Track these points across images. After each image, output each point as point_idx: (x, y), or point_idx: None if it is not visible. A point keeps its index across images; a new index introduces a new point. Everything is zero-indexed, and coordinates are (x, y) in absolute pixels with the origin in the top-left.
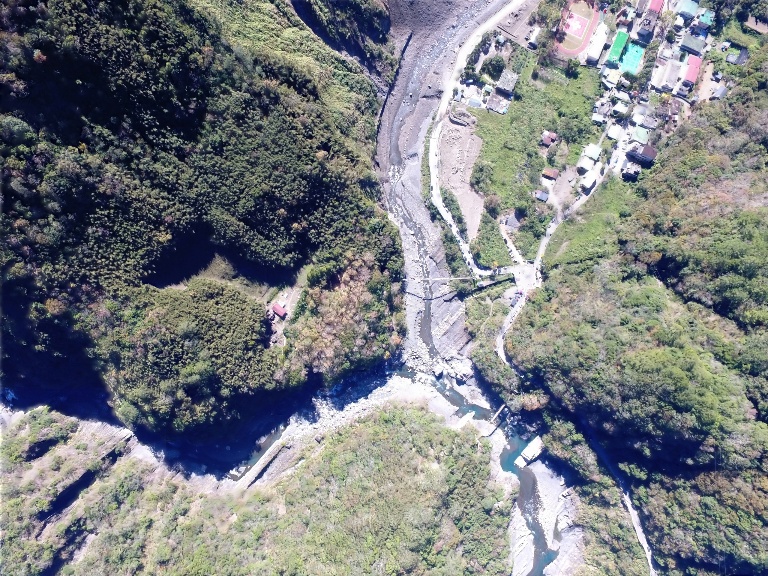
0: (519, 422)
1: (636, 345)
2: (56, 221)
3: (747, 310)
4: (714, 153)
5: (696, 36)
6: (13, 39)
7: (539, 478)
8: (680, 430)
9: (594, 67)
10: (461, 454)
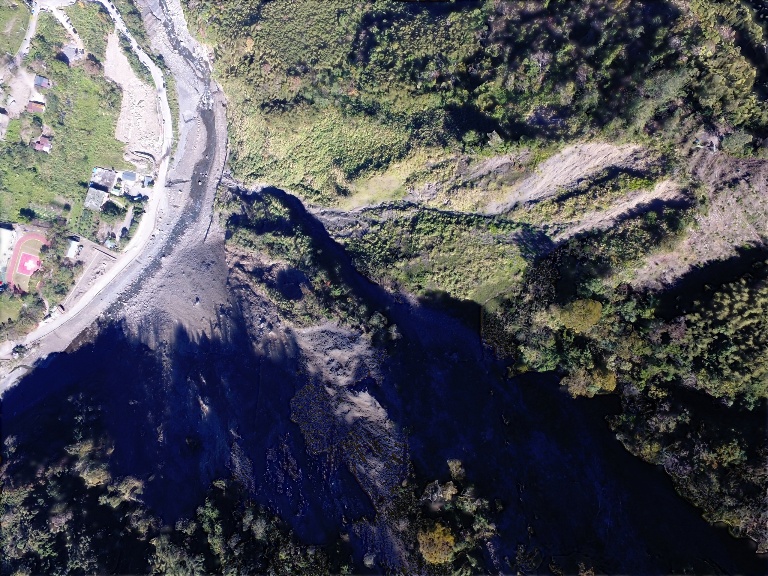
0: None
1: None
2: None
3: None
4: None
5: None
6: None
7: None
8: None
9: (3, 222)
10: None
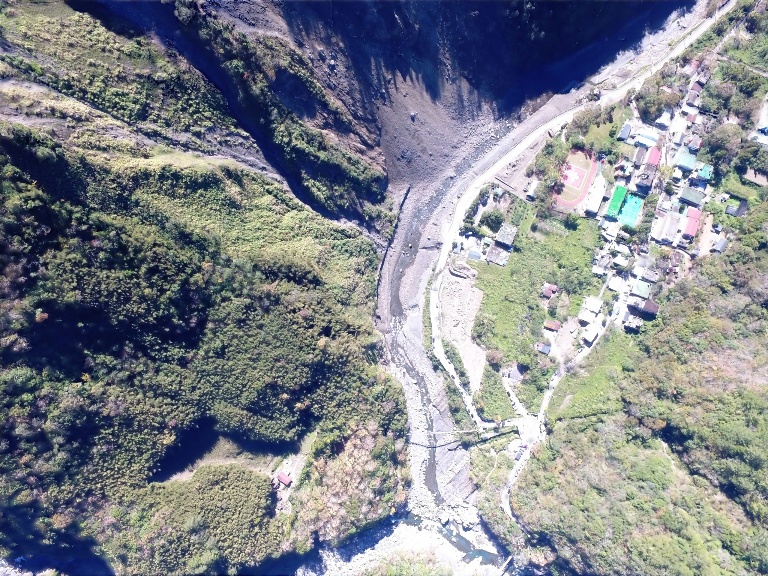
0: None
1: (642, 528)
2: (61, 451)
3: (754, 501)
4: (716, 312)
5: (695, 187)
6: (15, 308)
7: None
8: None
9: (593, 219)
10: None
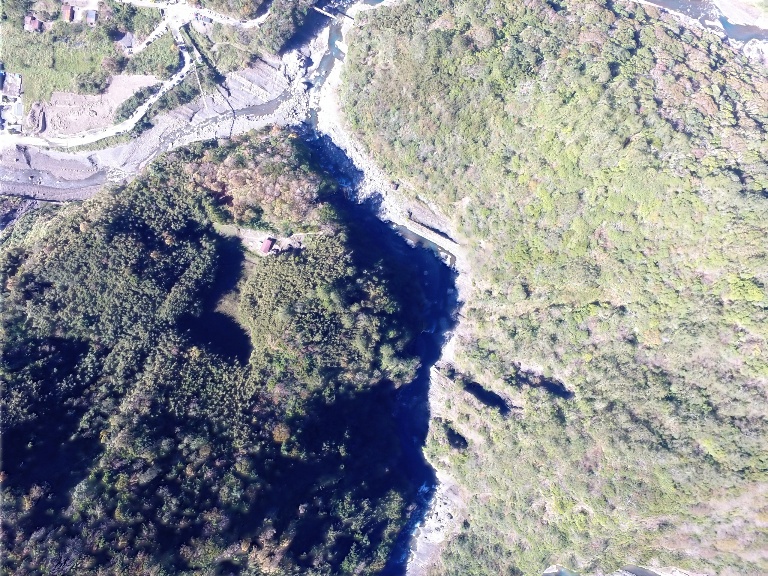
0: None
1: None
2: None
3: None
4: None
5: None
6: None
7: None
8: None
9: None
10: None
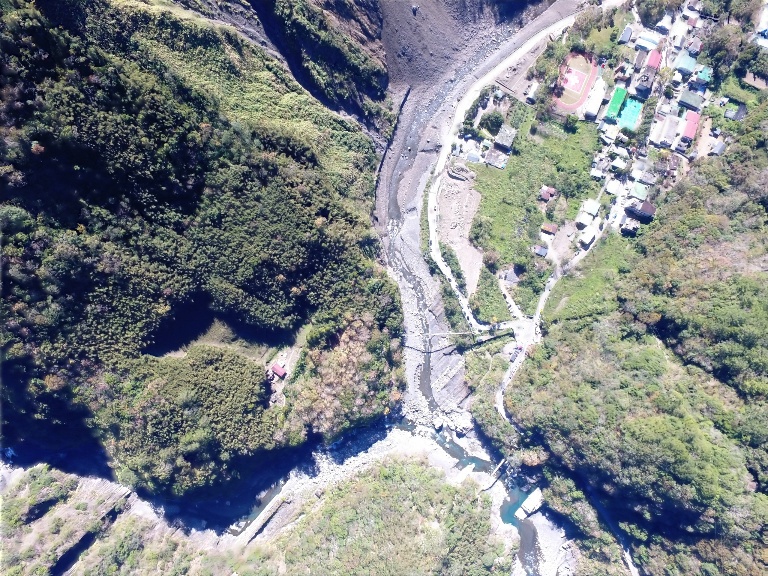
0: (519, 474)
1: (636, 411)
2: (55, 302)
3: (746, 379)
4: (713, 211)
5: (694, 91)
6: (11, 134)
7: (539, 530)
8: (680, 500)
9: (592, 122)
10: (461, 511)
